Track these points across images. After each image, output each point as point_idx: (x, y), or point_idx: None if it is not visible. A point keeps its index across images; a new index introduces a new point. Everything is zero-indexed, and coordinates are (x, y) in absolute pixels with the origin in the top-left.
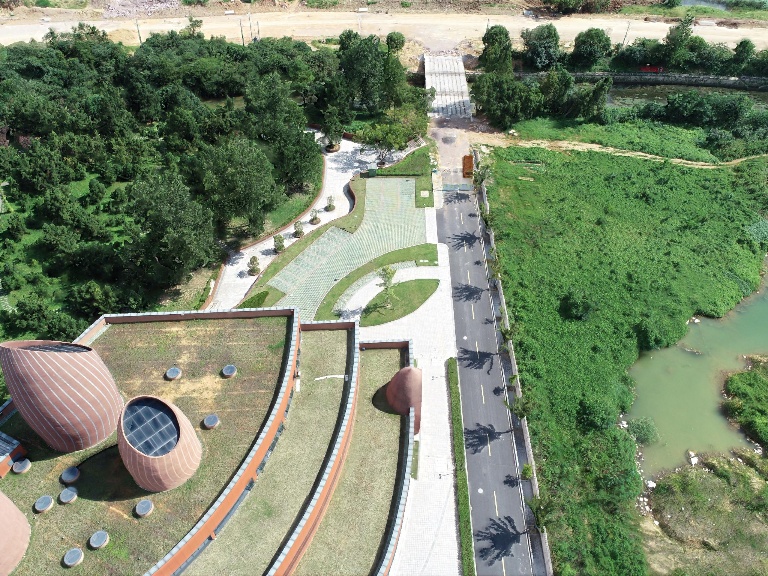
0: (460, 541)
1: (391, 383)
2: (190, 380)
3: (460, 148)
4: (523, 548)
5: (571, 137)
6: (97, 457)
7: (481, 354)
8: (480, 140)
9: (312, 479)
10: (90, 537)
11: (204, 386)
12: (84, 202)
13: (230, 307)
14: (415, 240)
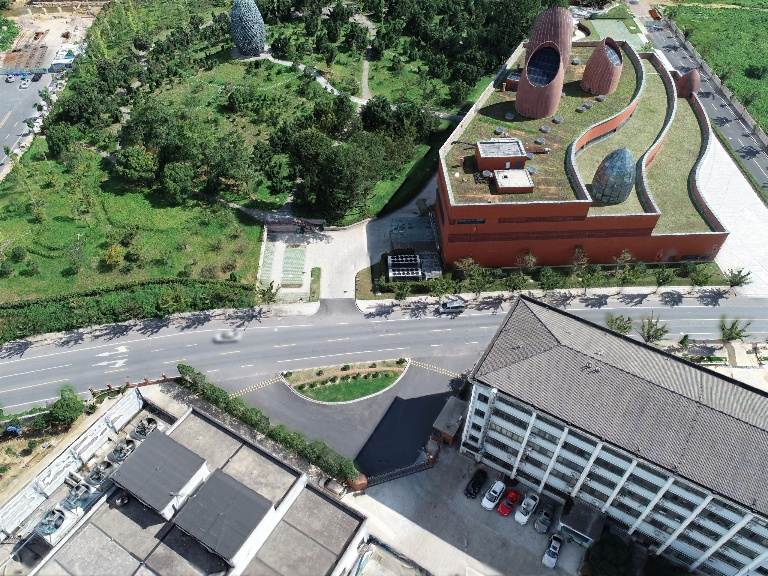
0: (728, 152)
1: (679, 82)
2: None
3: (644, 7)
4: (762, 155)
5: (718, 2)
6: (563, 86)
7: (705, 93)
8: (656, 3)
9: (666, 103)
10: None
11: None
12: None
13: None
14: (639, 47)
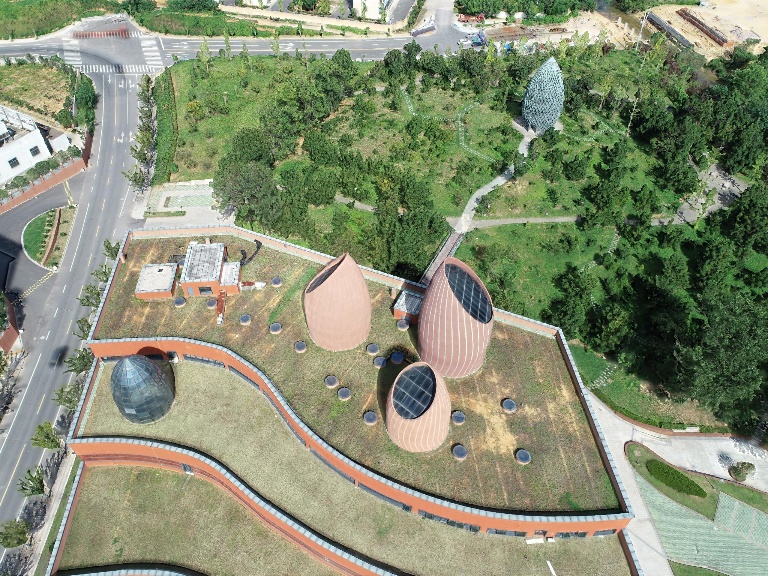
0: None
1: None
2: (505, 422)
3: None
4: None
5: None
6: None
7: None
8: None
9: (419, 573)
10: (347, 387)
11: (501, 437)
12: (742, 275)
13: (667, 457)
14: None
